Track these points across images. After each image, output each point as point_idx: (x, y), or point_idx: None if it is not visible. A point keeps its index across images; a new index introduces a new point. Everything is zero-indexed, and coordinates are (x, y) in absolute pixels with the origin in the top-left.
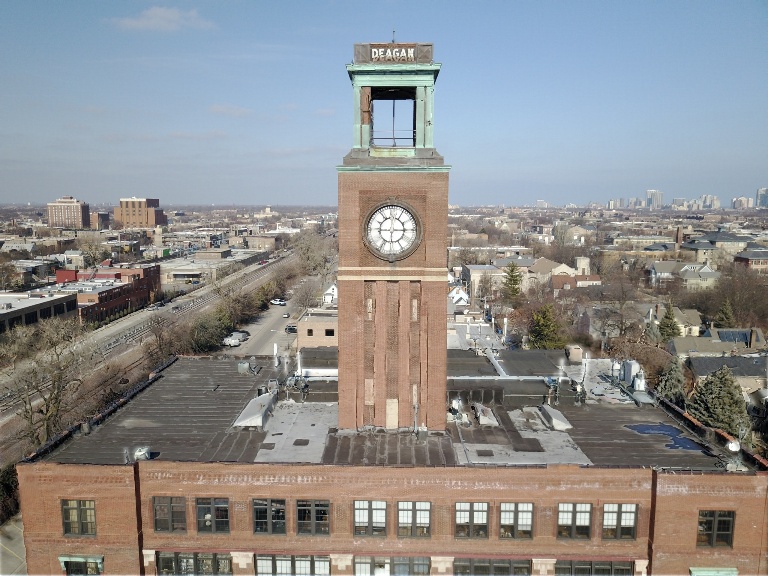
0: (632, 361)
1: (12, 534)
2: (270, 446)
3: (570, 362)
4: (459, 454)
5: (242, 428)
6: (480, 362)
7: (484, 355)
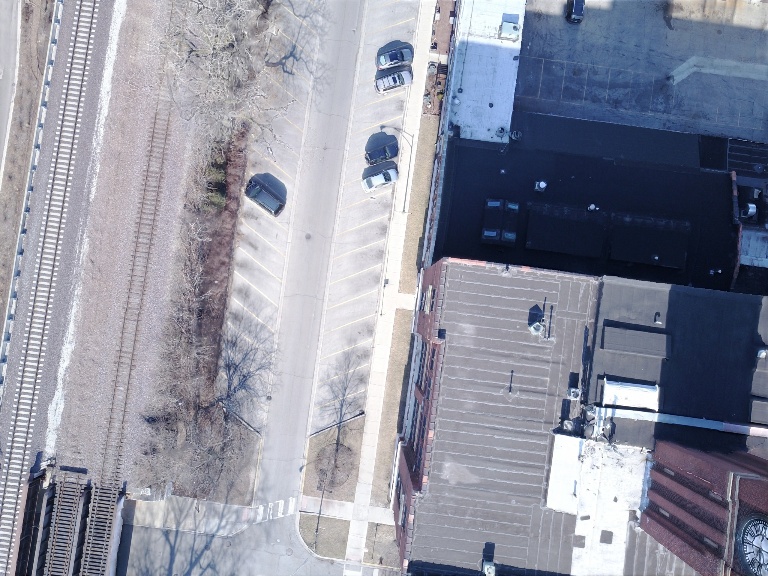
0: None
1: (252, 240)
2: (581, 542)
3: None
4: None
5: (556, 511)
6: None
7: None
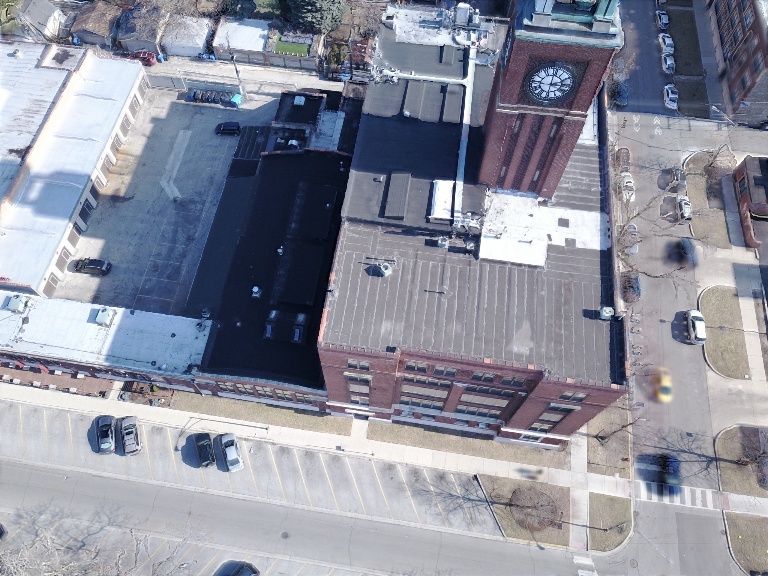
0: (462, 5)
1: None
2: (571, 241)
3: (394, 31)
4: (582, 142)
5: None
6: (425, 87)
7: (397, 79)
